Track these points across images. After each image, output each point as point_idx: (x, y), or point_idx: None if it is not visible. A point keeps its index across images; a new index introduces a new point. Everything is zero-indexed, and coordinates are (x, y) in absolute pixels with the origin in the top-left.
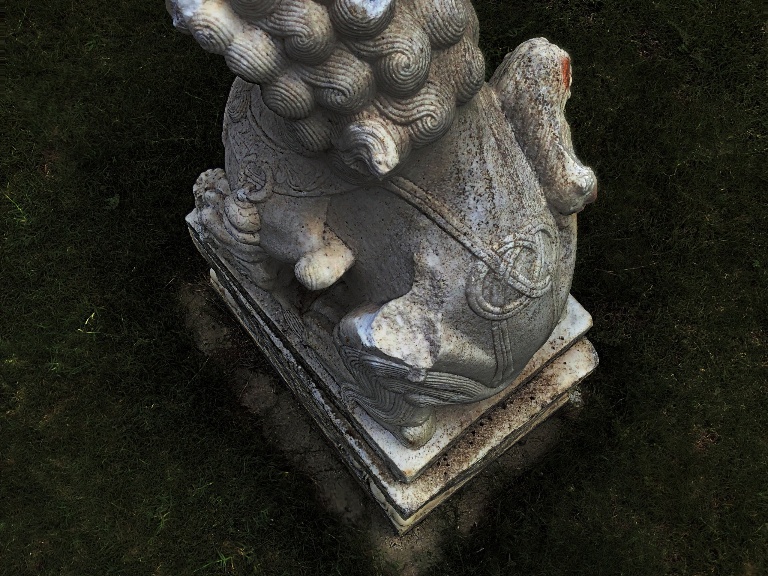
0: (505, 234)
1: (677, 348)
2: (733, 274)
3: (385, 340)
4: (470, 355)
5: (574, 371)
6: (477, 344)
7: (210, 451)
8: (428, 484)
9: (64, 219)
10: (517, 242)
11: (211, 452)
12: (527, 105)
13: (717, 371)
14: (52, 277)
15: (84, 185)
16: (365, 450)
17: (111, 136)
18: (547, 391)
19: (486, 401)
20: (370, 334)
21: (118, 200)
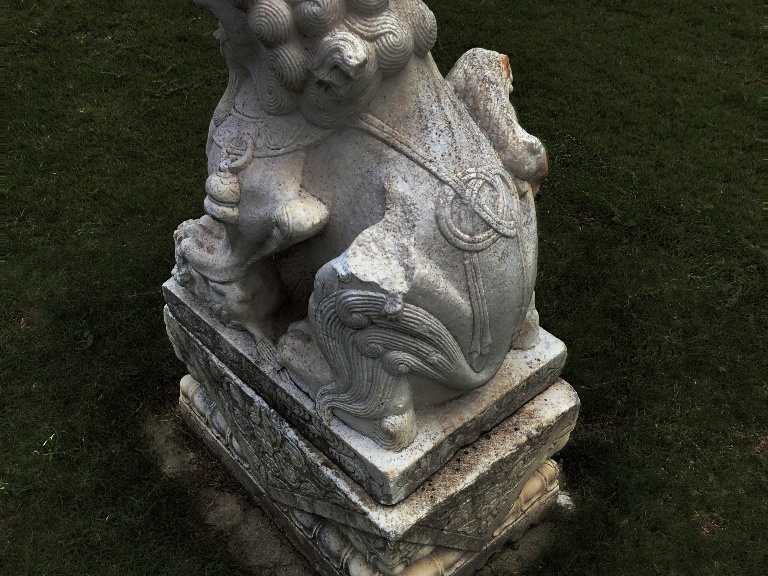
0: (467, 166)
1: (662, 445)
2: (702, 380)
3: (360, 266)
4: (445, 289)
5: (556, 406)
6: (451, 281)
7: (168, 559)
8: (413, 507)
9: (34, 359)
10: (479, 174)
11: (169, 561)
12: (476, 85)
13: (707, 462)
14: (14, 409)
15: (59, 331)
16: (343, 479)
17: (91, 294)
18: (531, 423)
19: (468, 410)
20: (346, 262)
21: (91, 341)
